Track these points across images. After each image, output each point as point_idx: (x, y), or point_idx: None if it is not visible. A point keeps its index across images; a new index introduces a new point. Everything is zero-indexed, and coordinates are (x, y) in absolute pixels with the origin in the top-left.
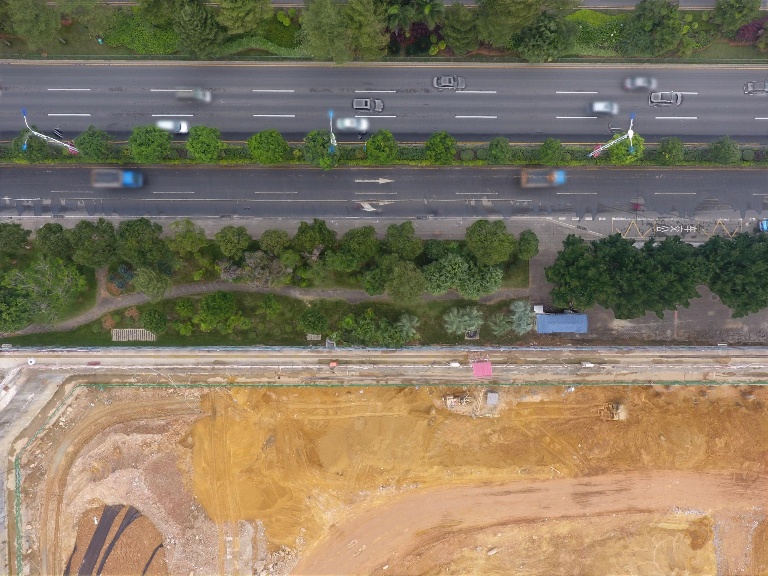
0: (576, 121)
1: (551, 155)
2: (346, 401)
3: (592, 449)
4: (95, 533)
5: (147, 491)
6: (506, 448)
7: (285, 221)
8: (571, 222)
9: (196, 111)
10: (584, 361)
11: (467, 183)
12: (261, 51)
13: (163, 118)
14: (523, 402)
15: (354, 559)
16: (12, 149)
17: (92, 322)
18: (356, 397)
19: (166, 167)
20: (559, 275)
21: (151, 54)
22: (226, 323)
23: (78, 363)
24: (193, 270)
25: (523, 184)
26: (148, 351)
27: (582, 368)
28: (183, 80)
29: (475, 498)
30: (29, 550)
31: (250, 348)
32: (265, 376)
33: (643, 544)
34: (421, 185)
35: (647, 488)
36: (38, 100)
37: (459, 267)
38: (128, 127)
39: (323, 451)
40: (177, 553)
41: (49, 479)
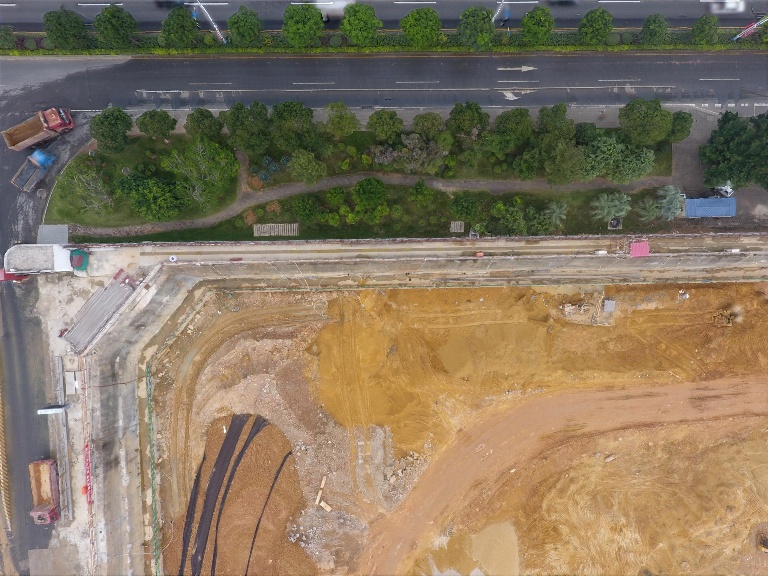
0: (719, 5)
1: (707, 31)
2: (466, 309)
3: (709, 354)
4: (224, 442)
5: (279, 397)
6: (623, 355)
7: (427, 111)
8: (713, 109)
9: None
10: (727, 249)
11: (610, 70)
12: None
13: None
14: (638, 310)
15: (482, 463)
16: (150, 38)
17: (233, 217)
18: (476, 305)
19: (306, 57)
20: (716, 153)
21: None
22: (373, 213)
23: (220, 259)
24: (335, 162)
25: (666, 70)
26: (290, 246)
27: (724, 256)
28: None
29: (597, 403)
30: (160, 459)
31: None
32: (396, 278)
33: (757, 448)
34: (564, 72)
35: (762, 392)
36: None
37: (614, 148)
38: (266, 16)
39: (446, 358)
40: (309, 458)
41: (177, 388)
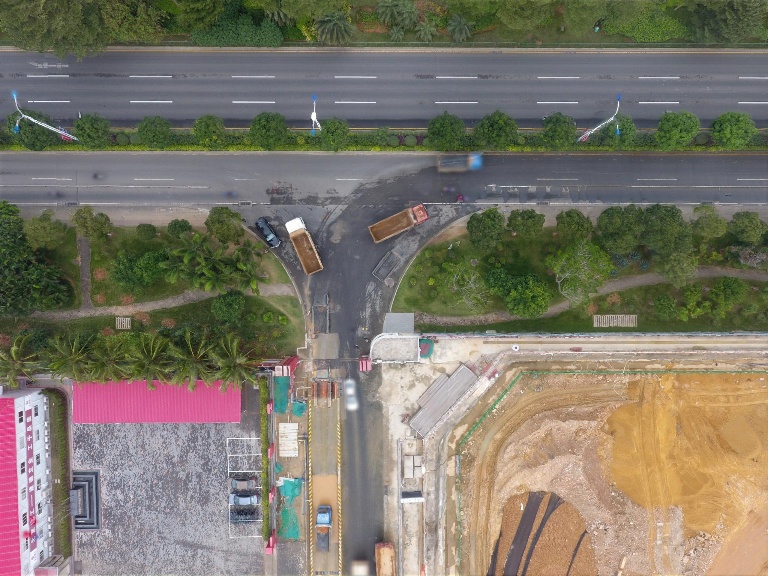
0: None
1: None
2: (746, 388)
3: None
4: (522, 519)
5: (583, 477)
6: None
7: (767, 207)
8: None
9: (682, 98)
10: None
11: None
12: (752, 38)
13: (649, 105)
14: None
15: None
16: None
17: (574, 308)
18: (756, 384)
19: (651, 154)
20: None
21: (647, 42)
22: (720, 308)
23: (560, 349)
24: None
25: None
26: (629, 337)
27: None
28: (671, 67)
29: None
30: (461, 536)
31: (742, 333)
32: (702, 363)
33: None
34: None
35: None
36: (528, 88)
37: None
38: None
39: (732, 438)
40: (609, 538)
41: (477, 466)
